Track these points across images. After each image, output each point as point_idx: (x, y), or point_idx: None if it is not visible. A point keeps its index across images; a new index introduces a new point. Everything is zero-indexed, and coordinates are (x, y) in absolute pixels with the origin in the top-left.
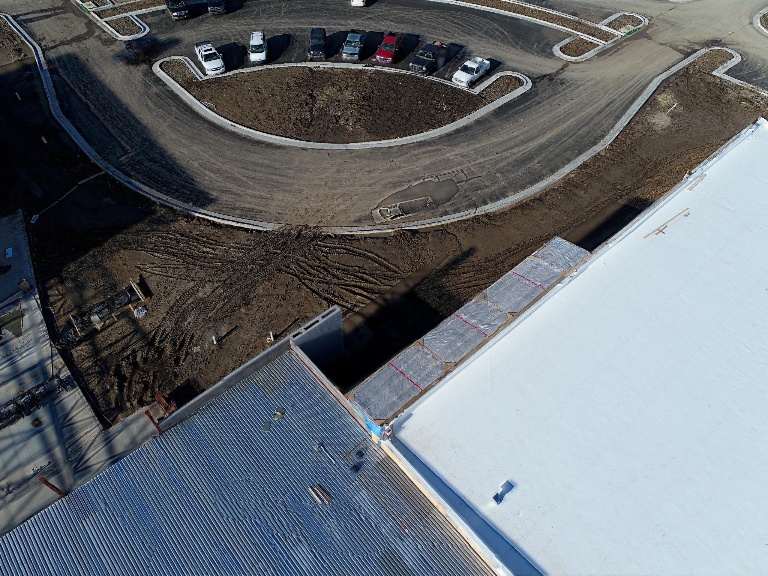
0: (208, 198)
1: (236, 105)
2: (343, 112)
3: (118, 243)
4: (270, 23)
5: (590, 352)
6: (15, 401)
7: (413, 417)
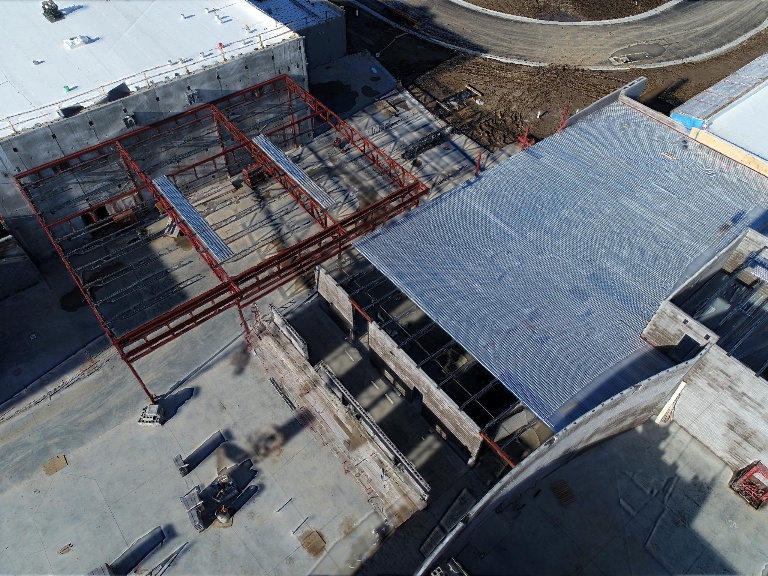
0: (489, 49)
1: None
2: (561, 4)
3: (443, 69)
4: None
5: None
6: (437, 132)
7: (714, 124)
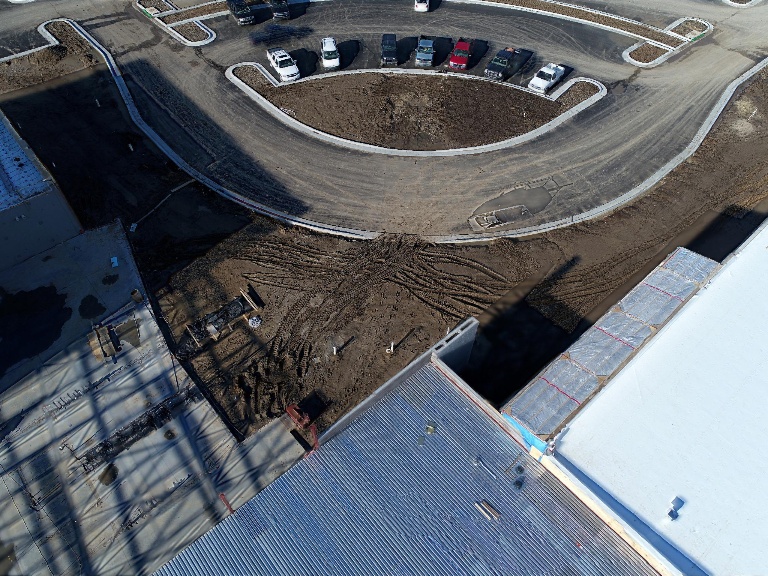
0: (302, 206)
1: (316, 112)
2: (423, 119)
3: (221, 252)
4: (336, 29)
5: (734, 365)
6: (150, 413)
7: (570, 431)
